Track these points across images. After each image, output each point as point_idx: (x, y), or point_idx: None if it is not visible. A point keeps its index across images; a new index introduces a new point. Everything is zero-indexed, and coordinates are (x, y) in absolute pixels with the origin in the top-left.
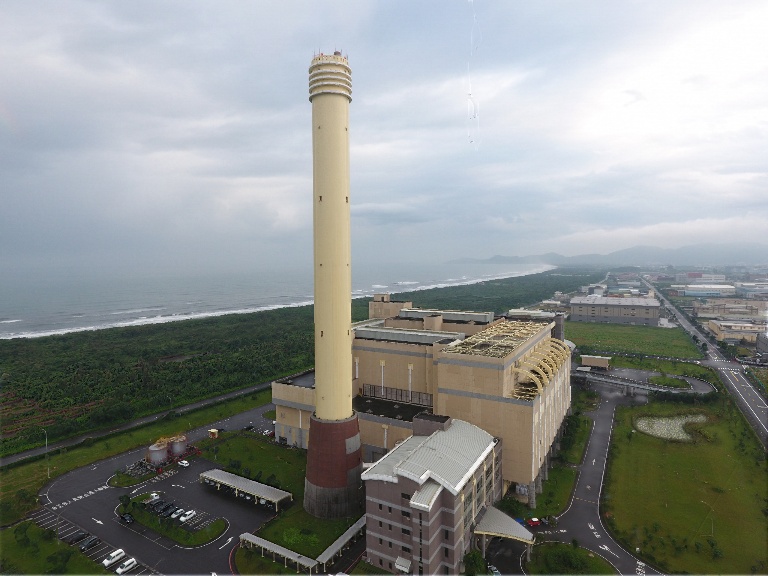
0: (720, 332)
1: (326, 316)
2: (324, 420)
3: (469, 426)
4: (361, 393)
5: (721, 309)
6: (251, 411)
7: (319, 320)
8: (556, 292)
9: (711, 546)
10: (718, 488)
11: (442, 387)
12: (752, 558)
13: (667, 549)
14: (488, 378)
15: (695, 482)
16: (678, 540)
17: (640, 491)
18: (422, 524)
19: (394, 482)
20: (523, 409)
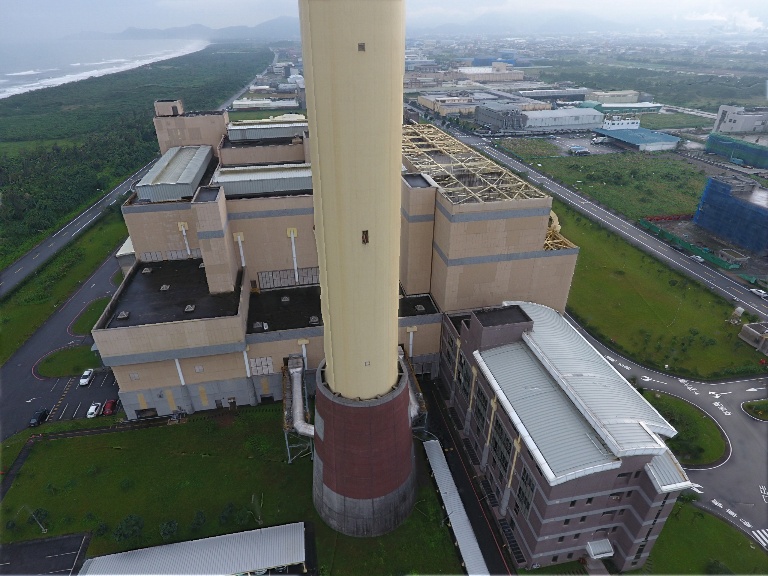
0: (442, 107)
1: (376, 193)
2: (377, 400)
3: (531, 307)
4: (255, 287)
5: (417, 83)
6: (2, 376)
7: (355, 206)
8: (257, 74)
9: (693, 335)
10: (621, 270)
11: (456, 257)
12: (713, 332)
13: (676, 354)
14: (527, 230)
15: (601, 270)
16: (668, 339)
17: (587, 297)
18: (666, 504)
19: (614, 468)
20: (565, 260)
